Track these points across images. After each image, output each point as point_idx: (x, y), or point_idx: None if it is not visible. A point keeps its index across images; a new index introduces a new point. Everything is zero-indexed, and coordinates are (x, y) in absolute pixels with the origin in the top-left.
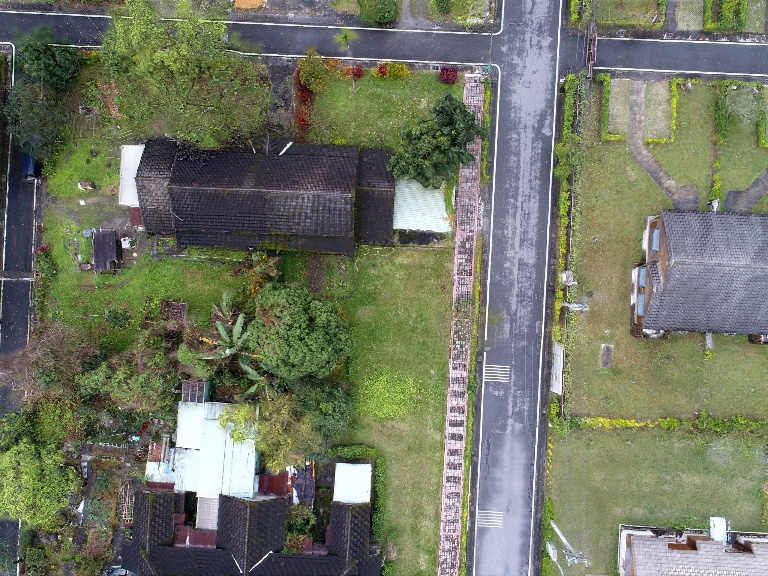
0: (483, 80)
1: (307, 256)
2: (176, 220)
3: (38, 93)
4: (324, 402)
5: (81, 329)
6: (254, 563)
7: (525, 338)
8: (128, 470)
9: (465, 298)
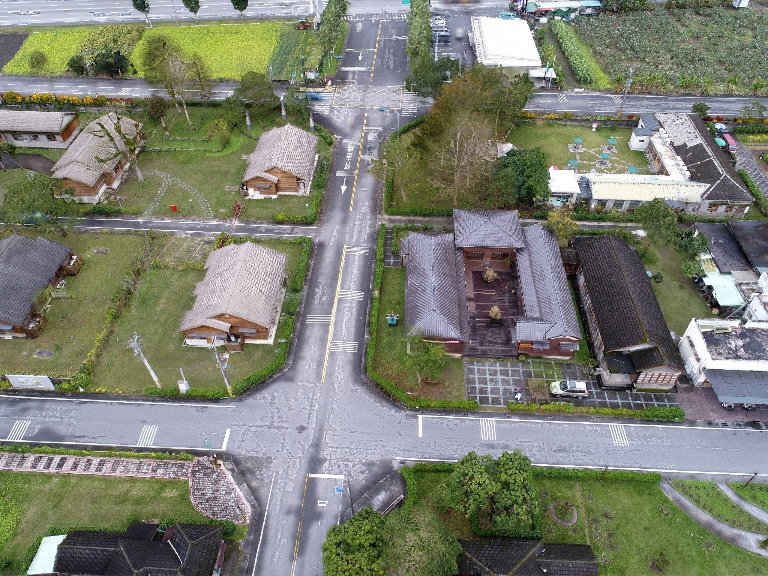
0: None
1: None
2: None
3: None
4: None
5: None
6: None
7: None
8: None
9: None
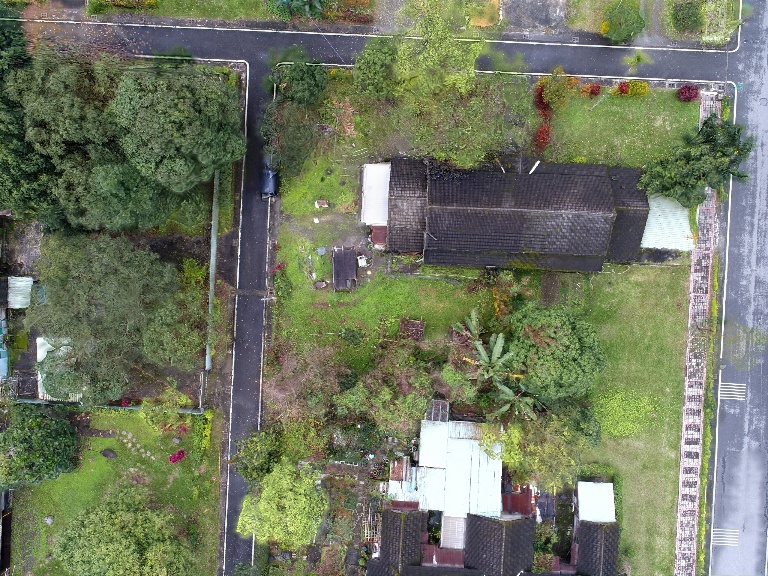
0: (721, 98)
1: (542, 274)
2: (430, 239)
3: (304, 113)
4: (584, 422)
5: (315, 347)
6: None
7: (761, 356)
8: (362, 488)
9: (701, 316)
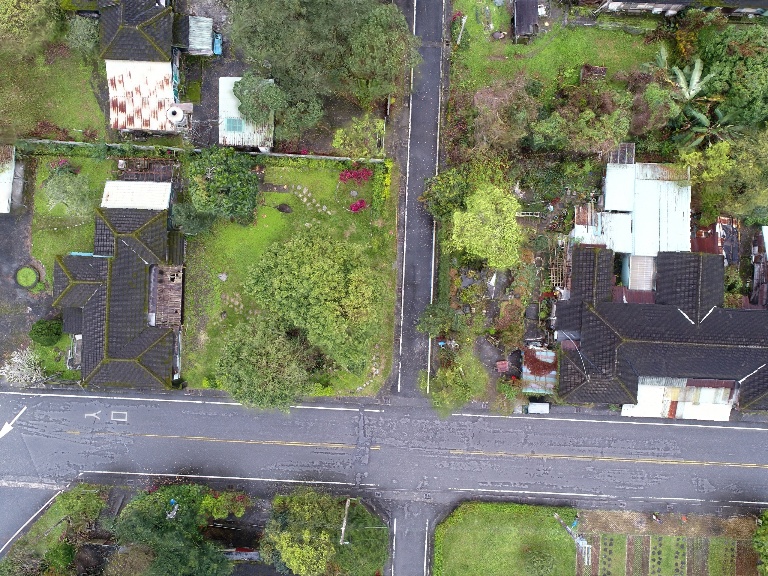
0: None
1: (719, 25)
2: None
3: None
4: None
5: None
6: (704, 315)
7: None
8: None
9: None
